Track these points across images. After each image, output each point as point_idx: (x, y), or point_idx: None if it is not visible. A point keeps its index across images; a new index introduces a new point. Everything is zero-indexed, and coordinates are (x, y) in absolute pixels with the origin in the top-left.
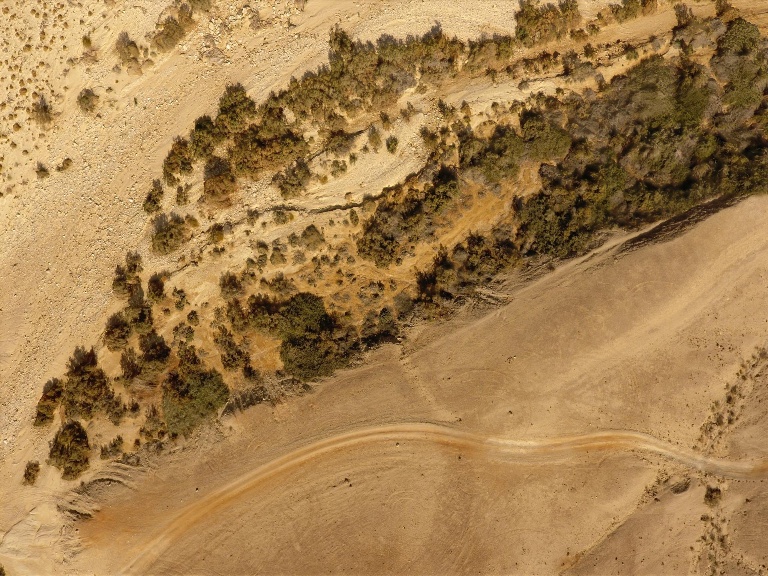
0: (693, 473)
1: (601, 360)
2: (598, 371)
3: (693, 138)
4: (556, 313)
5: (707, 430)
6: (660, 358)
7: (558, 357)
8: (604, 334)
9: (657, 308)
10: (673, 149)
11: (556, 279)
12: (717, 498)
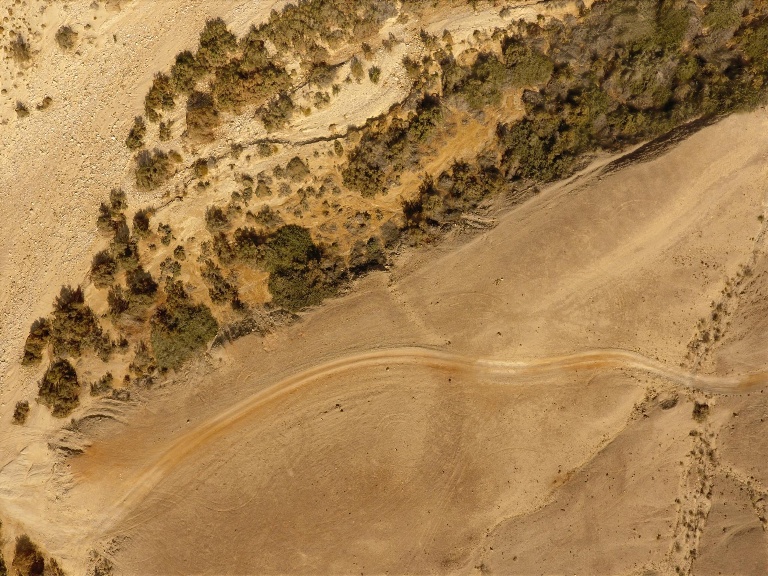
0: (681, 390)
1: (588, 280)
2: (585, 291)
3: (674, 60)
4: (542, 234)
5: (694, 347)
6: (646, 277)
7: (545, 278)
8: (590, 254)
9: (642, 227)
10: (654, 71)
11: (541, 201)
12: (705, 413)
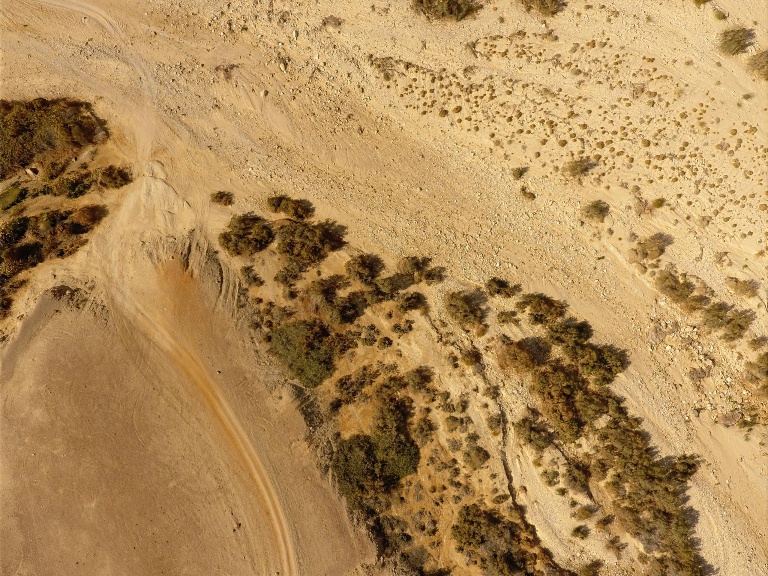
0: None
1: None
2: None
3: None
4: None
5: None
6: None
7: None
8: None
9: None
10: None
11: None
12: None
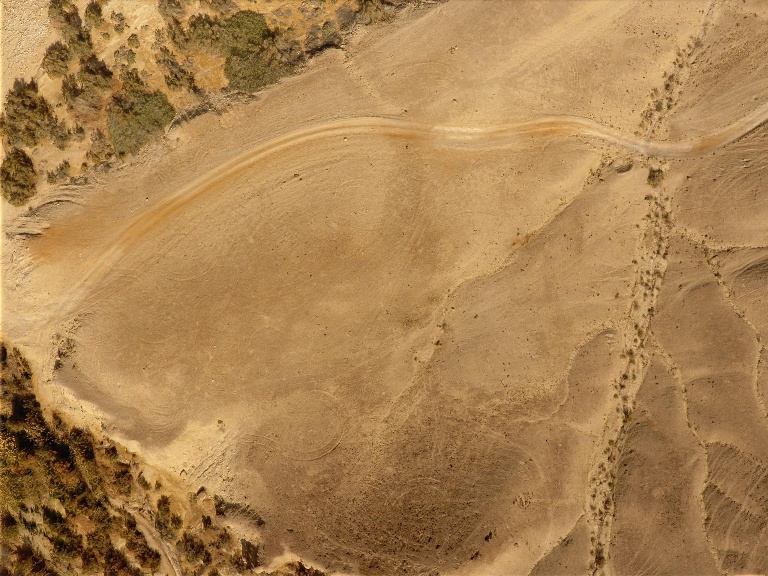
0: (636, 156)
1: (541, 47)
2: (538, 58)
3: None
4: (494, 3)
5: (647, 116)
6: (598, 45)
7: (498, 45)
8: (542, 20)
9: None
10: None
11: None
12: (659, 176)
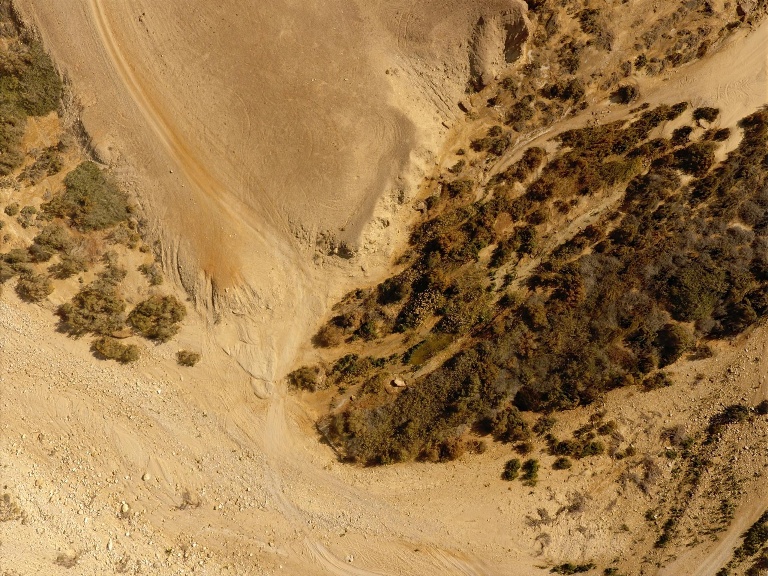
0: None
1: None
2: None
3: None
4: None
5: None
6: None
7: None
8: None
9: None
10: None
11: None
12: None
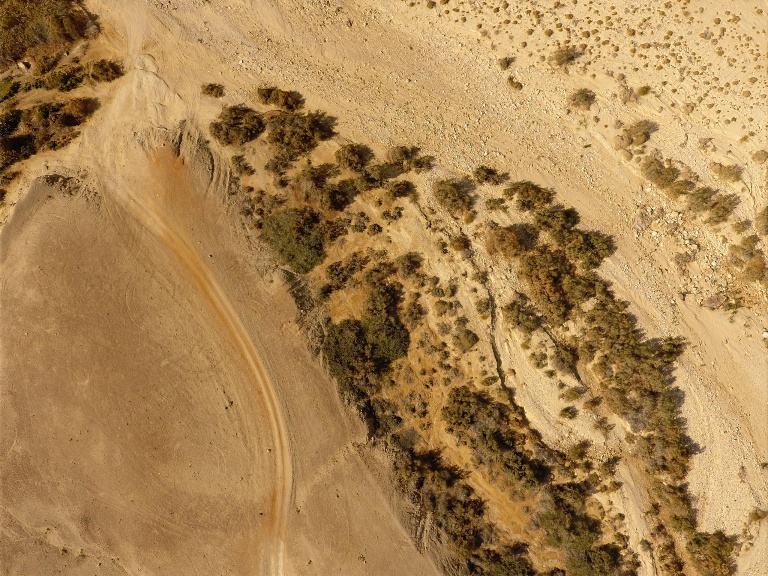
0: None
1: None
2: None
3: None
4: None
5: None
6: None
7: None
8: None
9: None
10: None
11: None
12: None
